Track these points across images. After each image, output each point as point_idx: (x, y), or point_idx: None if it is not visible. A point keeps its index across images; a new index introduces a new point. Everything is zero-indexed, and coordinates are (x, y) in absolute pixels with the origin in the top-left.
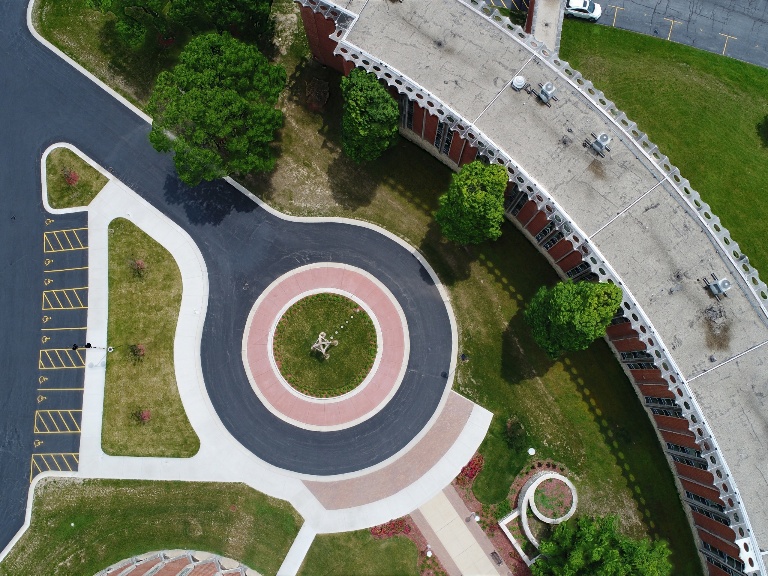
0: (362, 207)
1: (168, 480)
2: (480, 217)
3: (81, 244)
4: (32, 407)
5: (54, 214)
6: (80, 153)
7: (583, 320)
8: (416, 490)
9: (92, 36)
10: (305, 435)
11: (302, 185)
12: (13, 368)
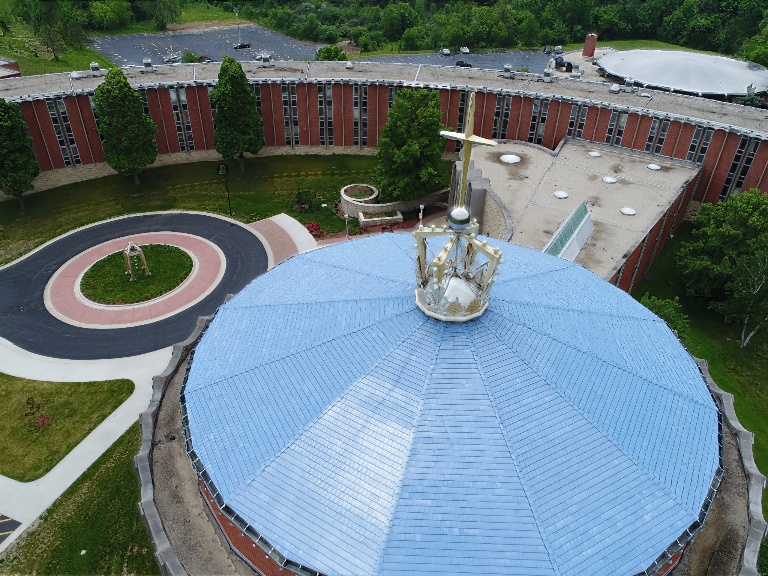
0: (58, 229)
1: (136, 420)
2: (132, 100)
3: None
4: None
5: None
6: None
7: (233, 71)
8: None
9: None
10: (201, 305)
11: None
12: None
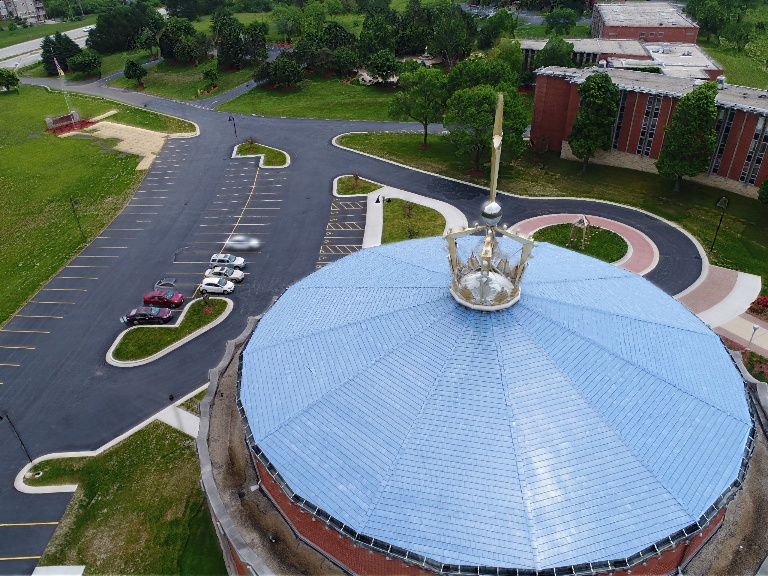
0: (584, 194)
1: None
2: (703, 113)
3: (361, 206)
4: (310, 270)
5: (341, 197)
6: (363, 178)
7: None
8: (709, 315)
9: (375, 146)
10: None
11: (533, 187)
12: (296, 253)
